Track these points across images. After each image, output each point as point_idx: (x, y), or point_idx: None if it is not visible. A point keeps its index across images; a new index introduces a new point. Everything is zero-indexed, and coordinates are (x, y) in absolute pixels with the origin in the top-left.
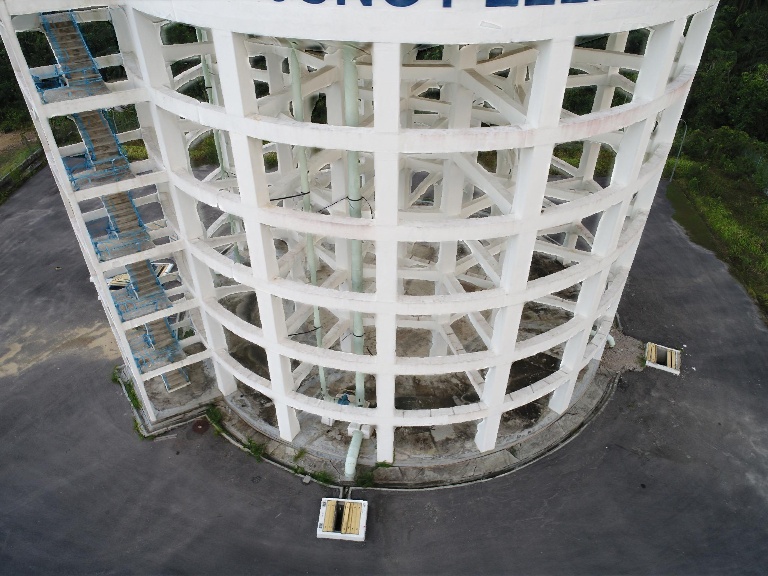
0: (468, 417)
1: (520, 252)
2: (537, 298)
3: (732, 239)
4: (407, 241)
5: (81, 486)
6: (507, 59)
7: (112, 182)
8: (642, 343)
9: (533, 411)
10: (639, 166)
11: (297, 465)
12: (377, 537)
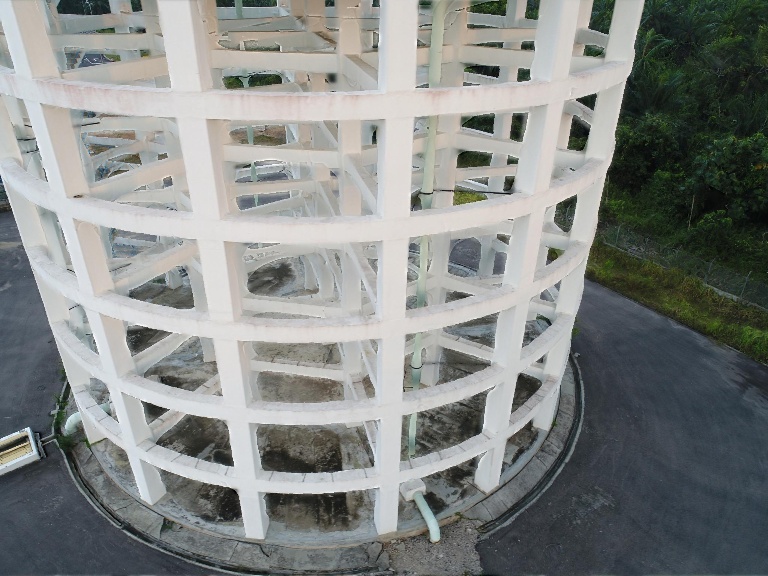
0: (109, 435)
1: (68, 238)
2: (112, 317)
3: None
4: (5, 180)
5: None
6: (271, 56)
7: None
8: (479, 572)
9: (235, 512)
10: (211, 197)
11: (69, 400)
12: (5, 483)
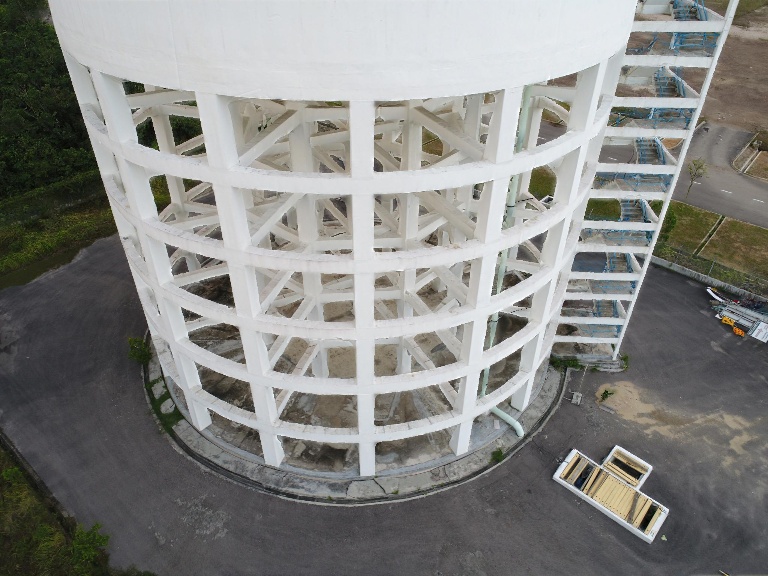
0: None
1: None
2: None
3: (59, 241)
4: None
5: (644, 305)
6: None
7: None
8: None
9: None
10: None
11: None
12: None
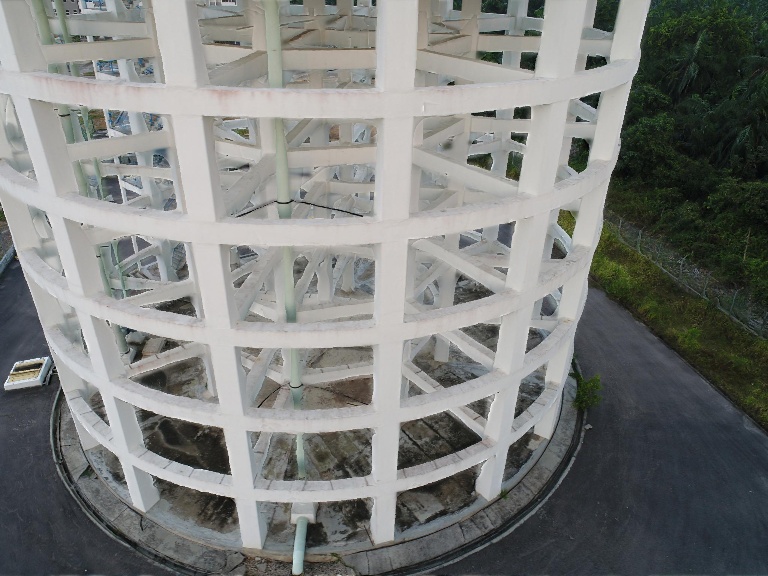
0: None
1: None
2: (26, 271)
3: None
4: None
5: None
6: (205, 48)
7: (111, 74)
8: None
9: None
10: (47, 173)
11: None
12: (8, 397)
